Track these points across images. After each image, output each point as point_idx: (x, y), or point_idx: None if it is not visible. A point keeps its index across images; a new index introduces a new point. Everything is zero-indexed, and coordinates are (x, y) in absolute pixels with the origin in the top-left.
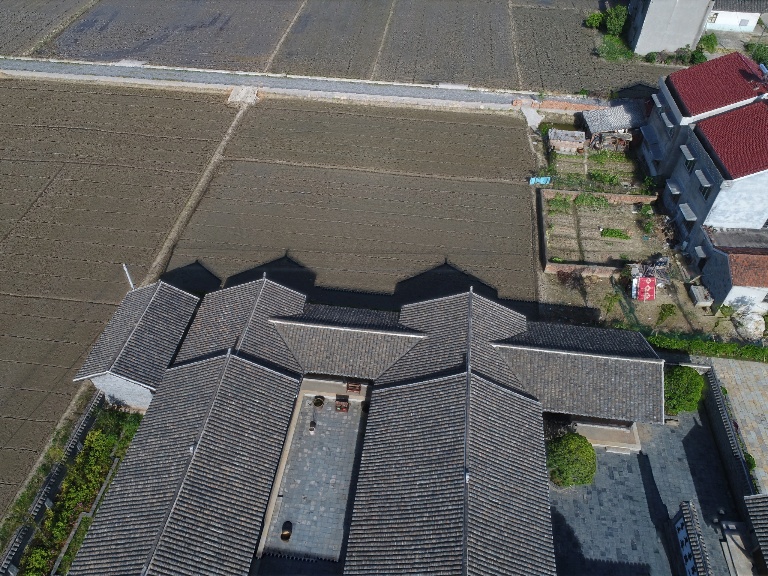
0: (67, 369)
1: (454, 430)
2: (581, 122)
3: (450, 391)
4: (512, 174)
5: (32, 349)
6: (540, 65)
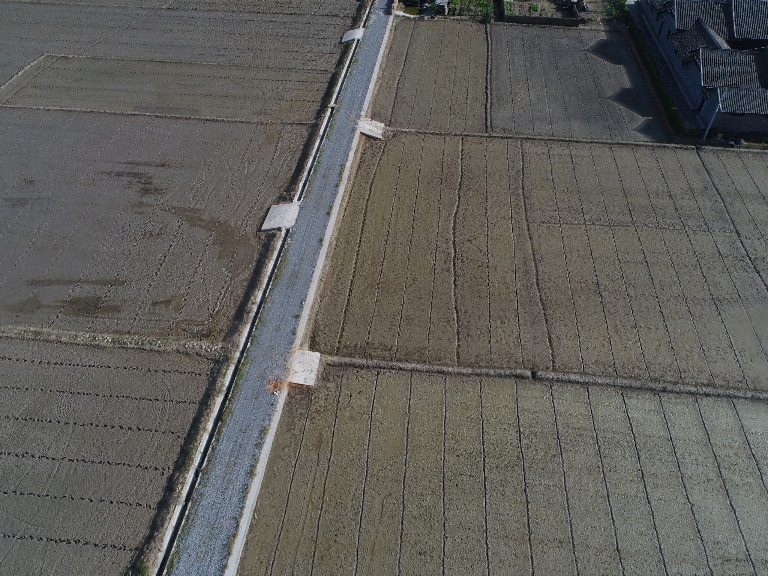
0: (765, 161)
1: (761, 4)
2: (405, 3)
3: (741, 5)
4: (479, 28)
5: (762, 179)
6: (306, 7)
